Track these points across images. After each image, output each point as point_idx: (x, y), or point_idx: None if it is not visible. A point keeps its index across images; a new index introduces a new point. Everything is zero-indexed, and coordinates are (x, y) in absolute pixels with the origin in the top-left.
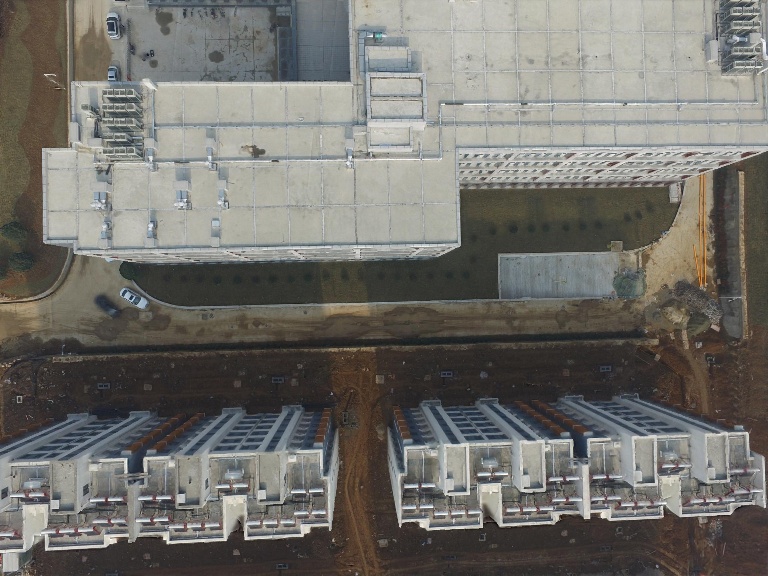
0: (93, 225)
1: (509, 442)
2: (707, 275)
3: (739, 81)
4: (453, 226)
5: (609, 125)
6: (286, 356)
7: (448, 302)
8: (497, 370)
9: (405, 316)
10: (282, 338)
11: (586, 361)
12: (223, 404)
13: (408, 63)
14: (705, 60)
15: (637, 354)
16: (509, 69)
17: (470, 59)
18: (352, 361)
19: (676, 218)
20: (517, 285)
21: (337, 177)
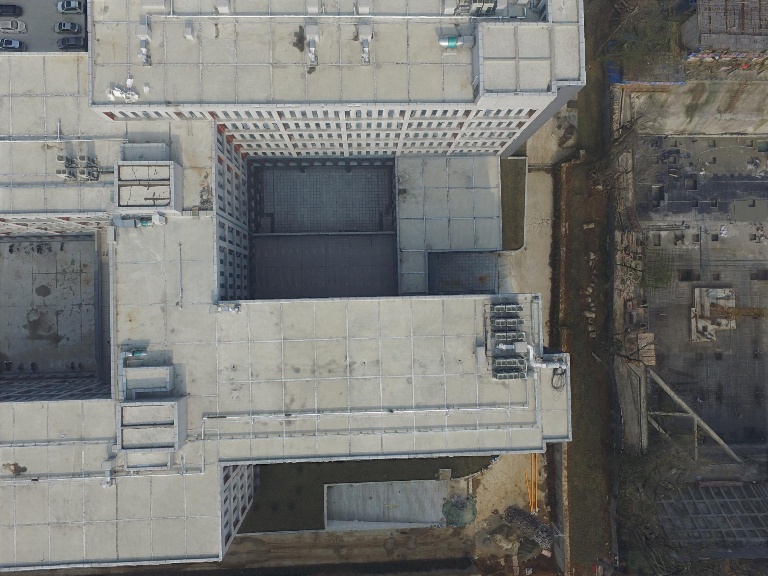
0: None
1: None
2: (539, 499)
3: (510, 383)
4: (215, 539)
5: (374, 434)
6: None
7: (273, 533)
8: None
9: (231, 546)
10: (107, 571)
11: None
12: None
13: (166, 383)
14: (475, 363)
15: None
16: (275, 378)
17: (235, 369)
18: None
19: None
20: (350, 507)
21: (99, 493)
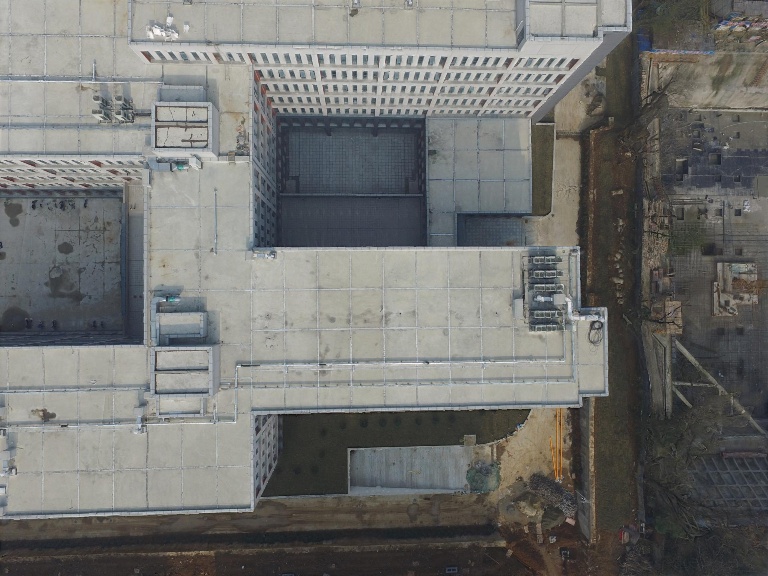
0: None
1: None
2: (563, 467)
3: (547, 337)
4: (247, 490)
5: (410, 386)
6: (123, 560)
7: (296, 497)
8: (340, 572)
9: None
10: (127, 533)
11: (431, 564)
12: None
13: (200, 329)
14: (512, 316)
15: (487, 551)
16: (310, 328)
17: (270, 318)
18: (190, 565)
19: (532, 410)
20: (372, 473)
21: (129, 440)
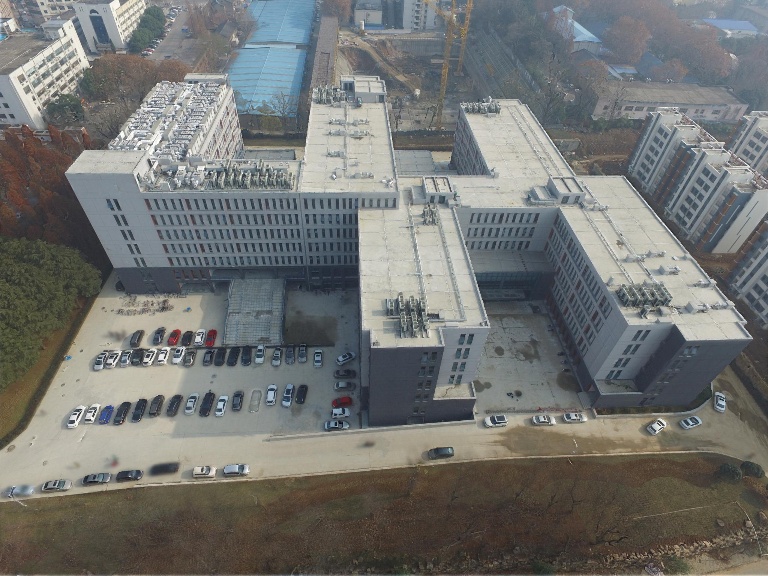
0: (720, 315)
1: (708, 164)
2: None
3: (500, 111)
4: None
5: None
6: None
7: None
8: None
9: None
10: None
11: None
12: (761, 332)
13: (542, 186)
14: (495, 117)
15: None
16: None
17: (525, 173)
18: None
19: None
20: None
21: (615, 214)
